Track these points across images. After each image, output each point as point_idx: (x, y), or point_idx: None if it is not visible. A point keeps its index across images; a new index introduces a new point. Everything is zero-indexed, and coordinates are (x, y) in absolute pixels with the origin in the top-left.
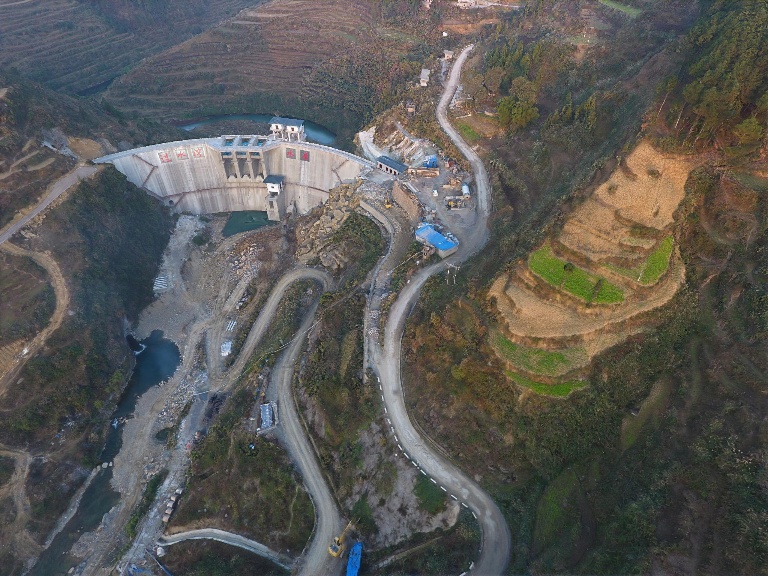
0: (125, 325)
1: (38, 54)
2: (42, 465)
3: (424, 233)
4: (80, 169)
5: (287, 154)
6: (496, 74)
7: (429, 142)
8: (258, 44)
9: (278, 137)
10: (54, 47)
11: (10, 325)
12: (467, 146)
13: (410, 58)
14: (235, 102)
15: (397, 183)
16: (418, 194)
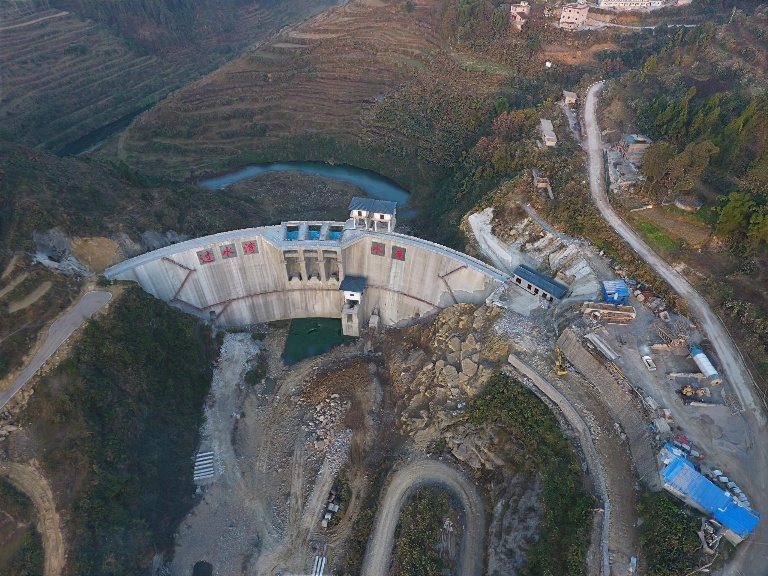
0: (154, 565)
1: (45, 87)
2: None
3: (681, 478)
4: (88, 296)
5: (372, 249)
6: (705, 152)
7: (592, 247)
8: (304, 72)
9: (358, 224)
10: (64, 77)
11: None
12: (664, 263)
13: (503, 95)
14: (280, 146)
15: (574, 334)
16: (620, 363)
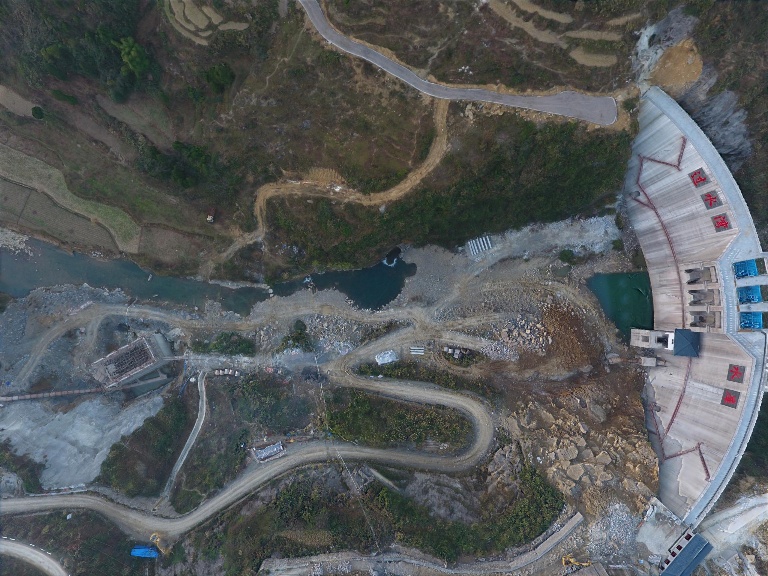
0: None
1: None
2: (259, 248)
3: None
4: (608, 102)
5: (736, 366)
6: None
7: None
8: None
9: None
10: None
11: (353, 167)
12: None
13: None
14: None
15: None
16: None
